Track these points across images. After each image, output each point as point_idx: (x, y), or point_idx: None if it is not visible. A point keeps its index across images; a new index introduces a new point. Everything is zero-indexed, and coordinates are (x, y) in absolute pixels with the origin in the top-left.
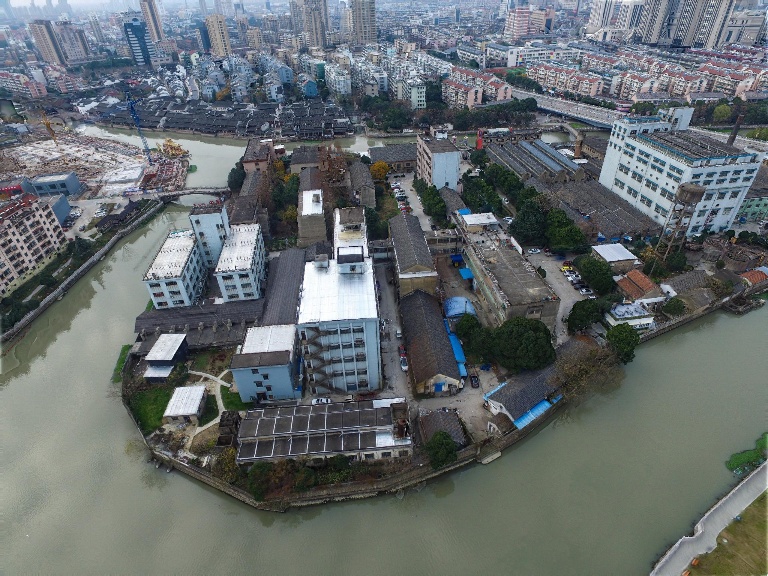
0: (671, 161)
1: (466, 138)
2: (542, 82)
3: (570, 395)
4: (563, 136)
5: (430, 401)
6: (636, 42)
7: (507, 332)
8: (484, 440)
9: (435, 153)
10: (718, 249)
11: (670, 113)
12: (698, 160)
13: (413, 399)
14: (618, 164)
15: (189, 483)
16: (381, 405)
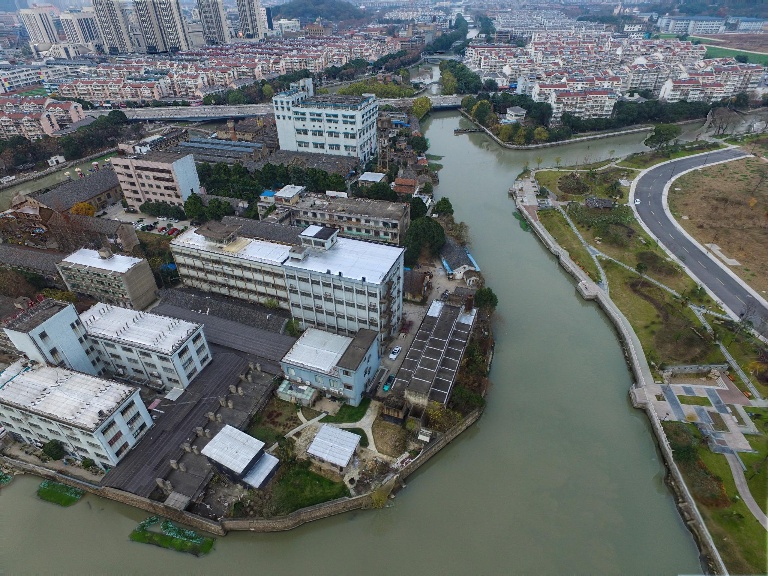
0: (342, 112)
1: (108, 160)
2: (88, 98)
3: (470, 243)
4: None
5: (430, 300)
6: (113, 53)
7: (421, 231)
8: (481, 286)
9: (172, 162)
10: (396, 157)
11: (301, 84)
12: (359, 106)
13: (423, 306)
14: (294, 130)
15: (415, 481)
16: (434, 312)
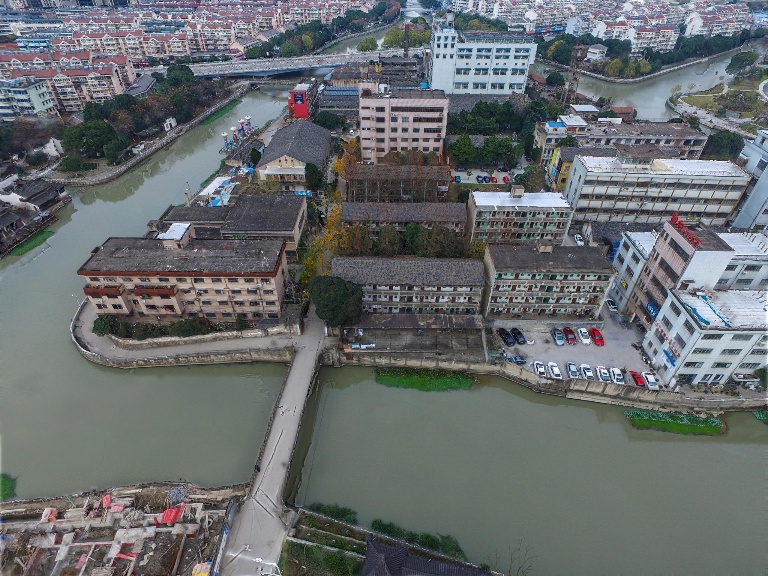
0: (516, 46)
1: None
2: None
3: None
4: (259, 93)
5: None
6: None
7: None
8: None
9: None
10: None
11: (449, 19)
12: None
13: None
14: (455, 70)
15: None
16: None
